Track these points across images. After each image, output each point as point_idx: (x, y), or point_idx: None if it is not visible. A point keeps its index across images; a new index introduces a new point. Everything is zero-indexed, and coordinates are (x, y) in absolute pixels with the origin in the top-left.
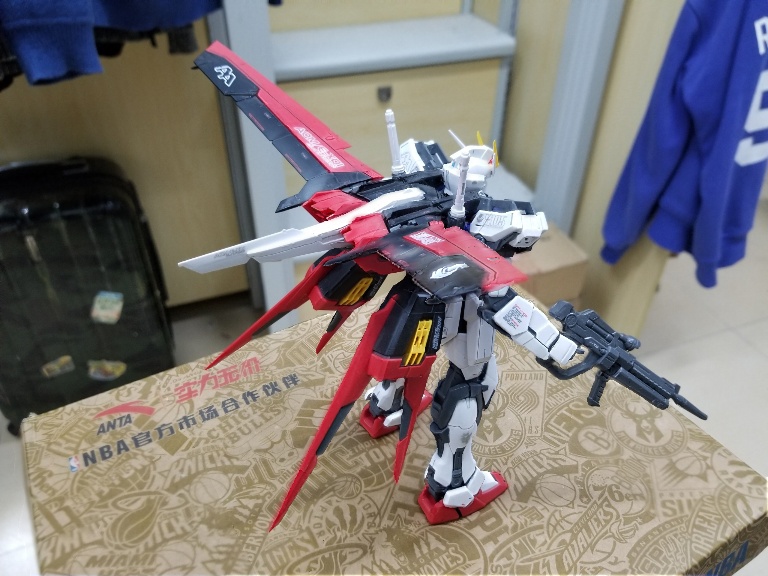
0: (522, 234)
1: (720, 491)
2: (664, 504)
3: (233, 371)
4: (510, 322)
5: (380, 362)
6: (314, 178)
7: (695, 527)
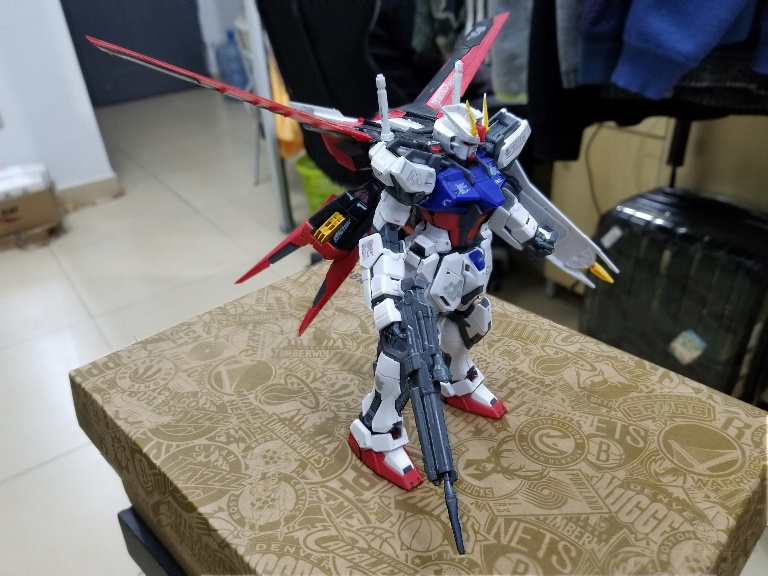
0: None
1: None
2: None
3: None
4: (364, 251)
5: None
6: None
7: None
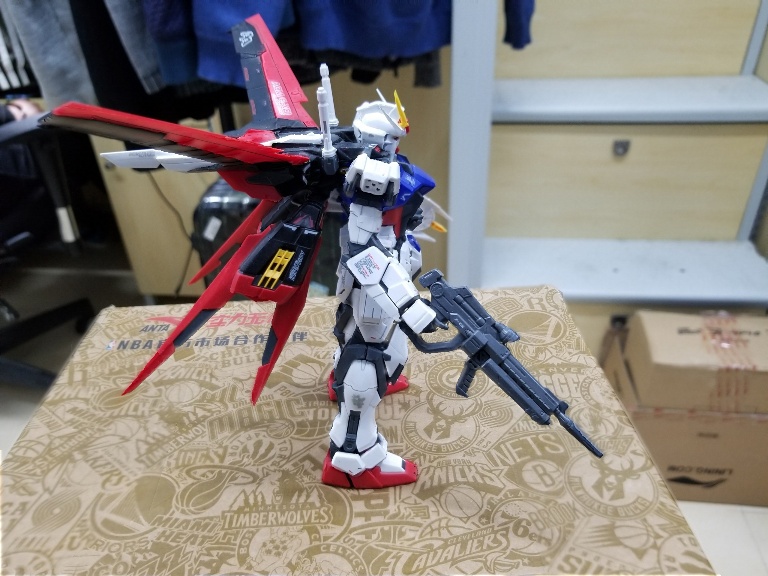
0: (363, 176)
1: (648, 574)
2: (567, 558)
3: (262, 316)
4: (361, 270)
5: (235, 275)
6: (261, 120)
7: None
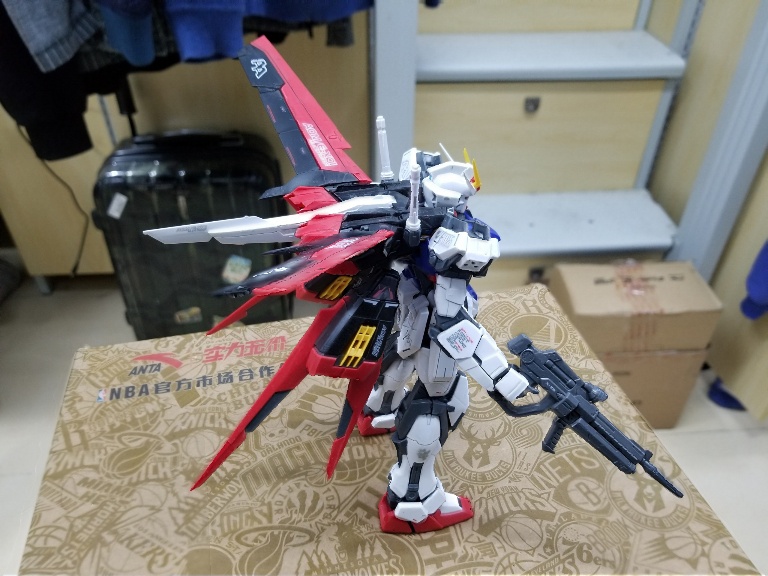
0: (465, 257)
1: None
2: None
3: (260, 344)
4: (454, 345)
5: (314, 357)
6: (304, 173)
7: None
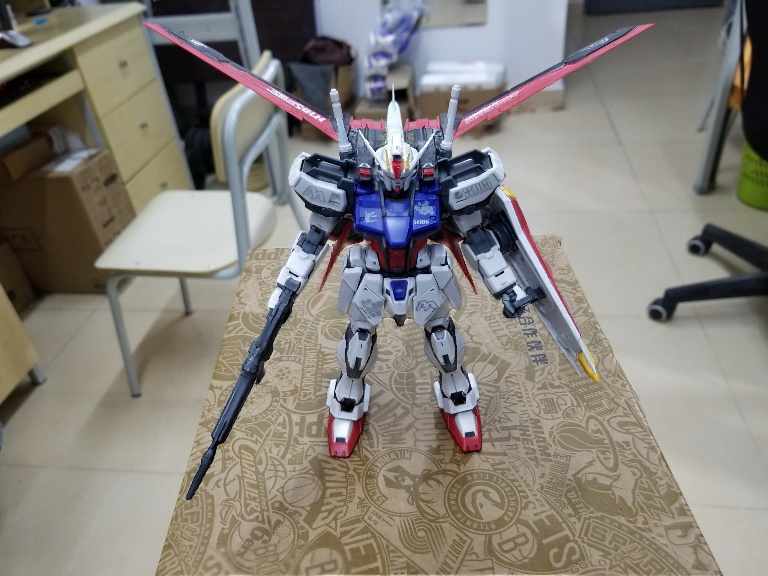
0: None
1: None
2: (218, 567)
3: None
4: None
5: None
6: None
7: (180, 571)
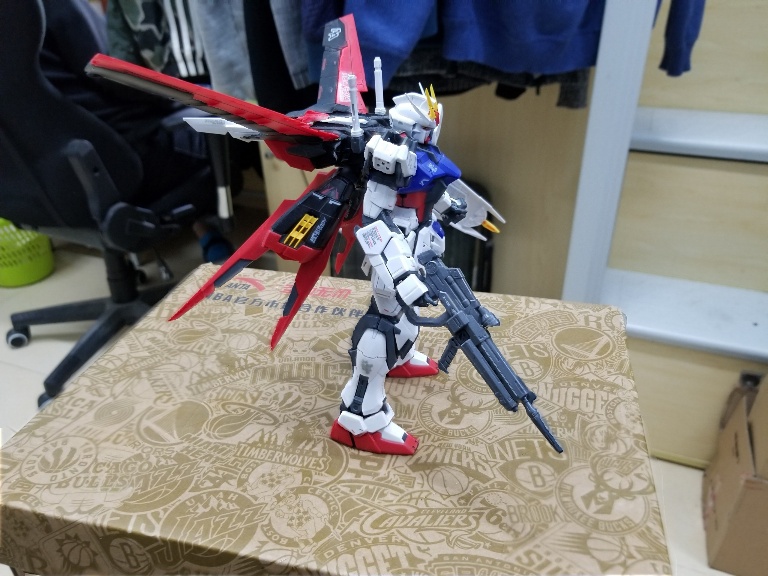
0: (373, 154)
1: None
2: (529, 553)
3: (329, 291)
4: (367, 240)
5: None
6: (322, 104)
7: None
